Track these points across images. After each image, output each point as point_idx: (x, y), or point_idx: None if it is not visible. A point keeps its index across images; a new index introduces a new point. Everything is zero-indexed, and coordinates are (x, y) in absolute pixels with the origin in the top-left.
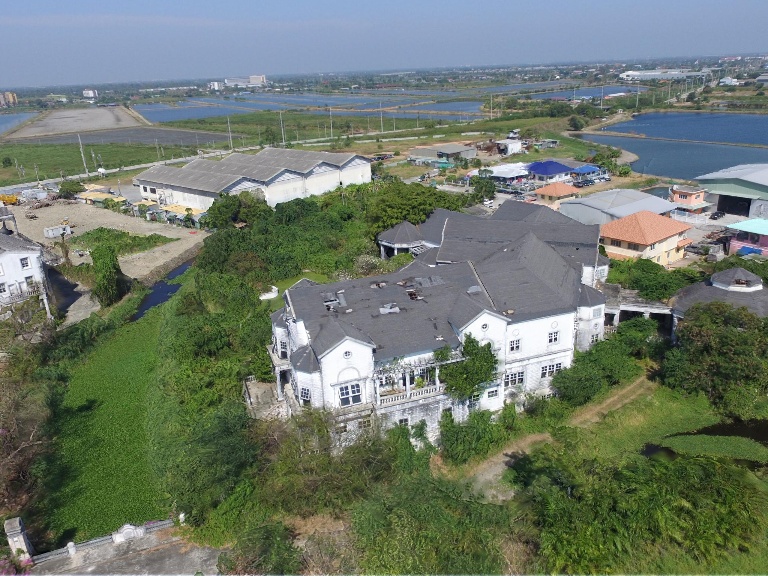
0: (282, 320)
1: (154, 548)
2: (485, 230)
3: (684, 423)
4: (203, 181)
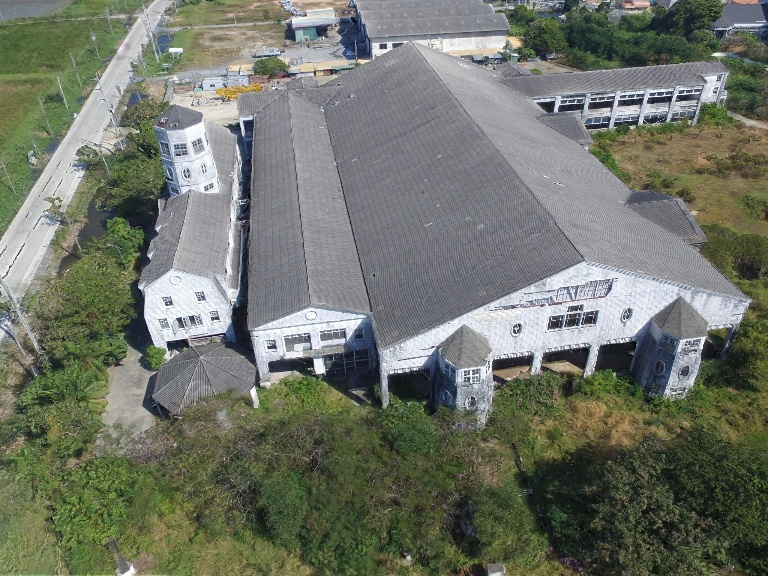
0: None
1: None
2: None
3: None
4: (473, 24)
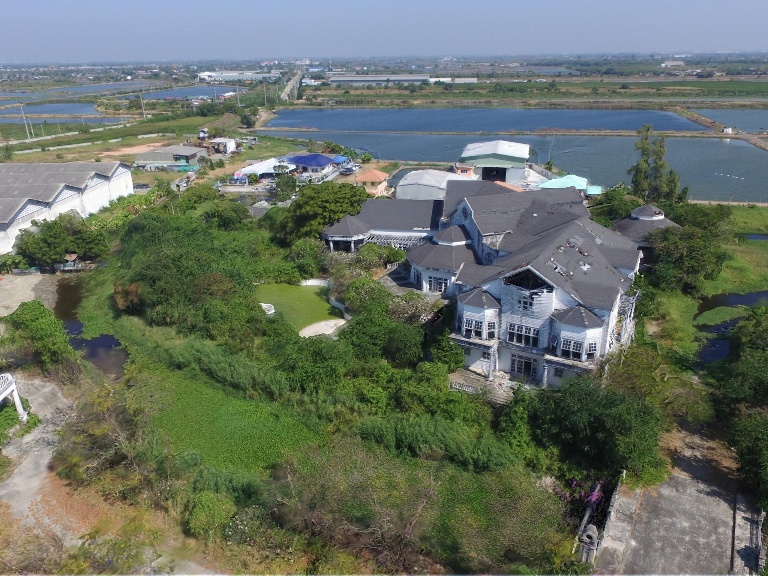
0: (490, 302)
1: (638, 505)
2: (502, 203)
3: (689, 309)
4: None
